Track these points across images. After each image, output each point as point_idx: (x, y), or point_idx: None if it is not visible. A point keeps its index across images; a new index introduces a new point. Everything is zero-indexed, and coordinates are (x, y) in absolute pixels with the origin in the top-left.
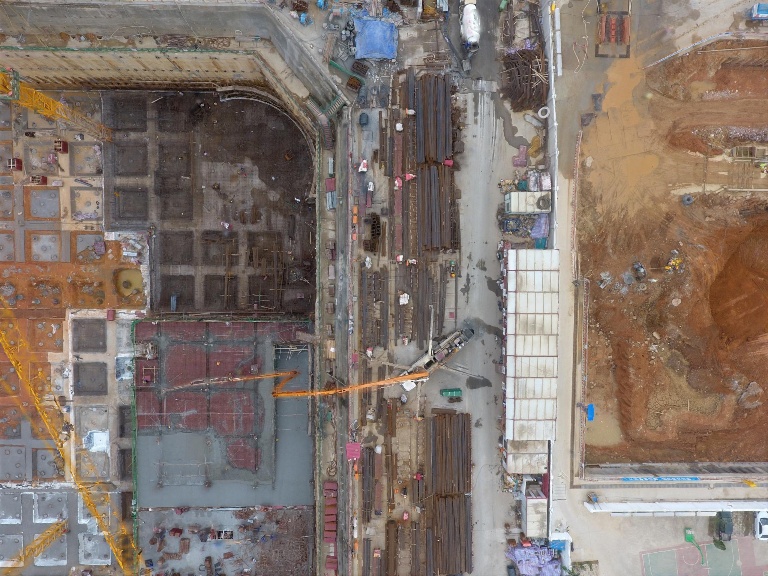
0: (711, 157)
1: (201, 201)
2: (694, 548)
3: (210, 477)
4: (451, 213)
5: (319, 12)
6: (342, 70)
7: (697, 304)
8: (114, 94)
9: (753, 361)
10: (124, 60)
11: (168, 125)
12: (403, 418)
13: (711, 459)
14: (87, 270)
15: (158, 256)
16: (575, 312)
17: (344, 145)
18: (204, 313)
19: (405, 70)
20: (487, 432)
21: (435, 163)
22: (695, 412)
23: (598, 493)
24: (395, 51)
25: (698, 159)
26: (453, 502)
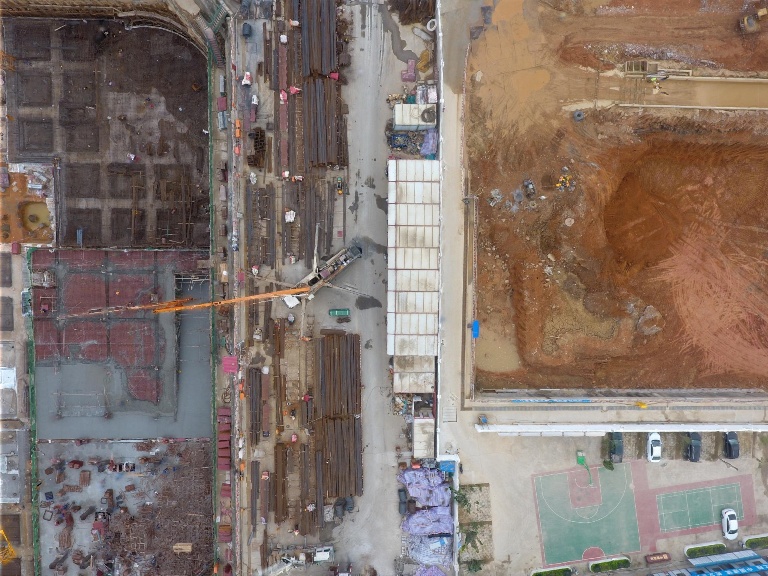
0: (602, 72)
1: (107, 132)
2: (586, 471)
3: (110, 408)
4: (337, 128)
5: None
6: None
7: (591, 225)
8: (16, 22)
9: (653, 287)
10: None
11: (73, 55)
12: (292, 339)
13: (610, 386)
14: None
15: (64, 189)
16: (465, 231)
17: (229, 58)
18: (111, 247)
19: None
20: (377, 354)
21: (321, 76)
22: (592, 337)
23: (489, 415)
24: None
25: (589, 74)
26: (342, 424)
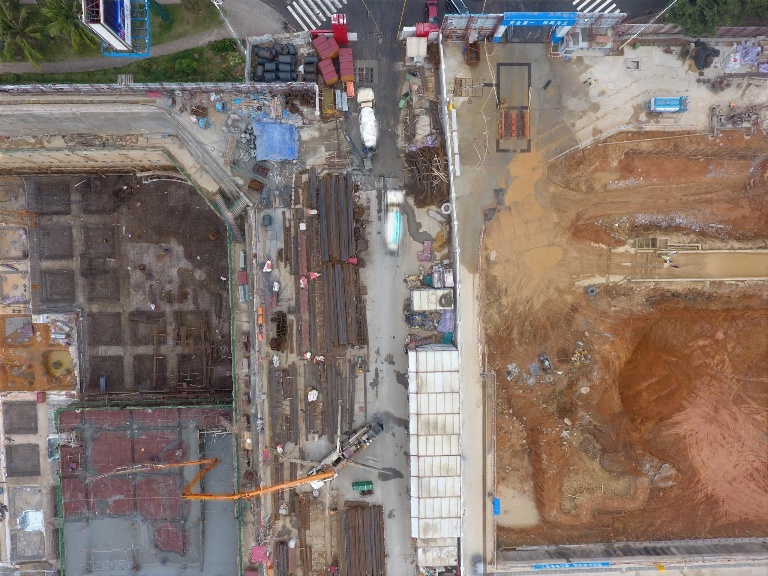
0: (614, 248)
1: (128, 282)
2: None
3: (138, 561)
4: (356, 310)
5: (219, 115)
6: (243, 172)
7: (606, 391)
8: (37, 178)
9: (668, 440)
10: (35, 157)
11: (93, 207)
12: (316, 511)
13: (628, 538)
14: (16, 353)
15: (86, 337)
16: (483, 404)
17: (250, 244)
18: (134, 393)
19: (307, 170)
20: (400, 523)
21: (340, 261)
22: (609, 494)
23: None
24: (296, 151)
25: (601, 250)
26: None
